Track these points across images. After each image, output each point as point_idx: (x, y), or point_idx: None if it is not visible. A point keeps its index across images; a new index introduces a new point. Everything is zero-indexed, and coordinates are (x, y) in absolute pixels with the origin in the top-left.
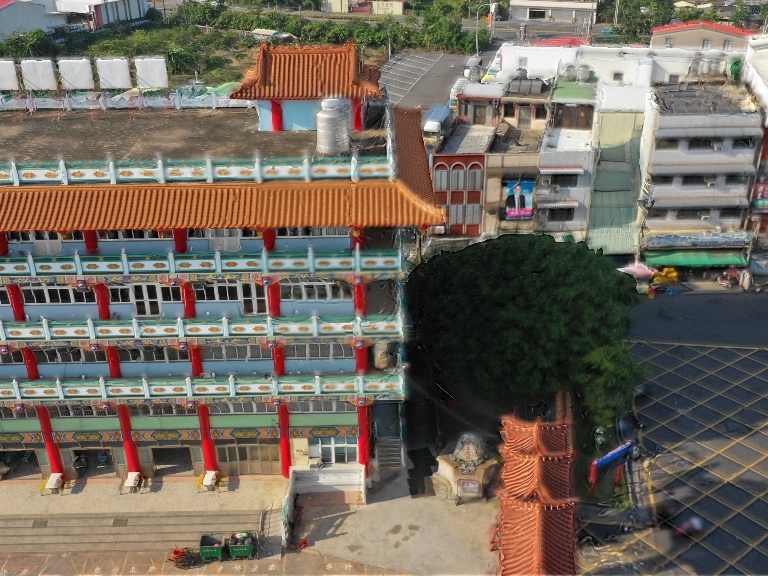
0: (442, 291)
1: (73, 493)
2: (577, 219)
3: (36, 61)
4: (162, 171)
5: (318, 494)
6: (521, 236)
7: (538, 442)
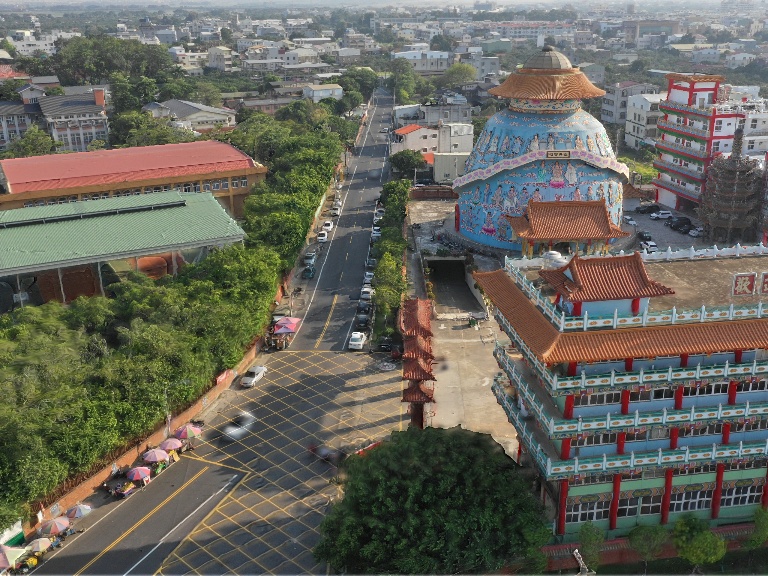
0: None
1: None
2: None
3: None
4: None
5: None
6: (438, 472)
7: None
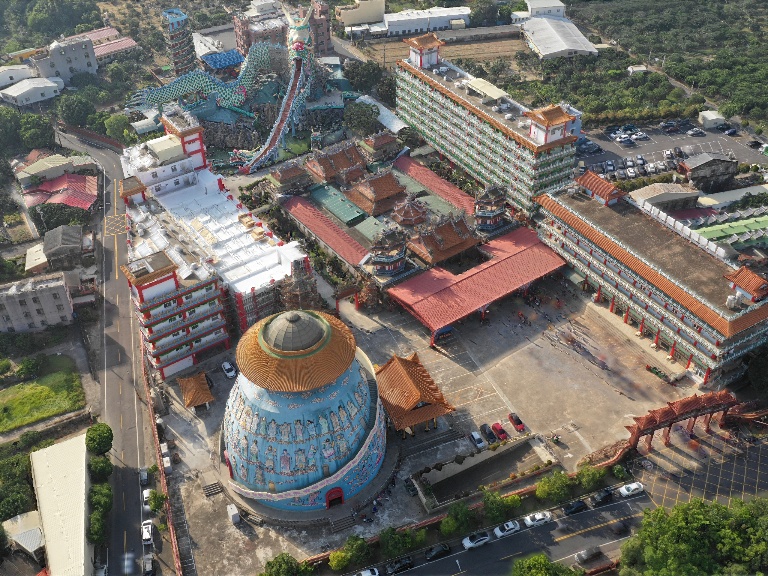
0: (765, 355)
1: (640, 339)
2: None
3: (696, 233)
4: (686, 289)
5: (690, 379)
6: None
7: (722, 395)
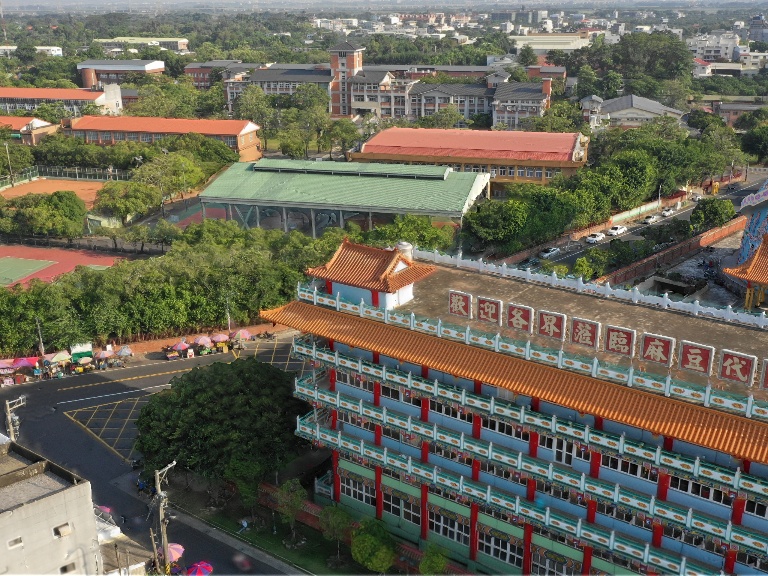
0: None
1: None
2: None
3: None
4: (505, 269)
5: None
6: None
7: None
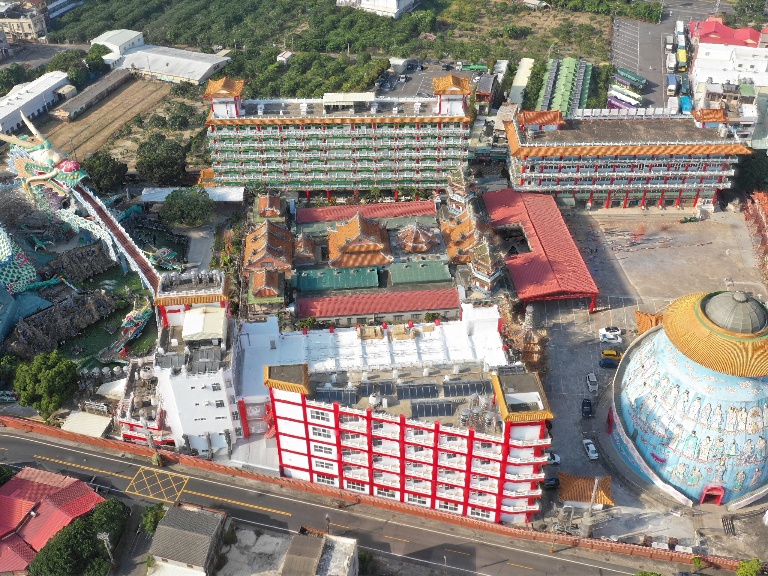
0: None
1: (648, 210)
2: (749, 137)
3: (642, 109)
4: (696, 142)
5: (702, 211)
6: None
7: None
